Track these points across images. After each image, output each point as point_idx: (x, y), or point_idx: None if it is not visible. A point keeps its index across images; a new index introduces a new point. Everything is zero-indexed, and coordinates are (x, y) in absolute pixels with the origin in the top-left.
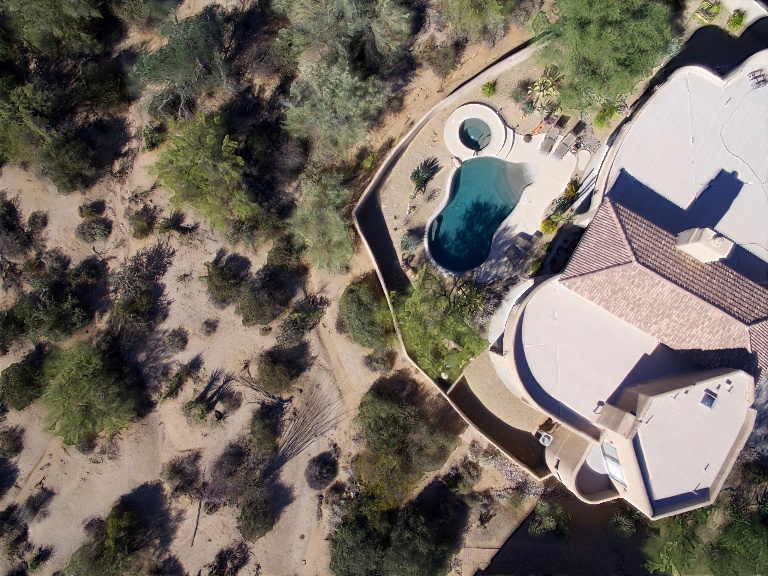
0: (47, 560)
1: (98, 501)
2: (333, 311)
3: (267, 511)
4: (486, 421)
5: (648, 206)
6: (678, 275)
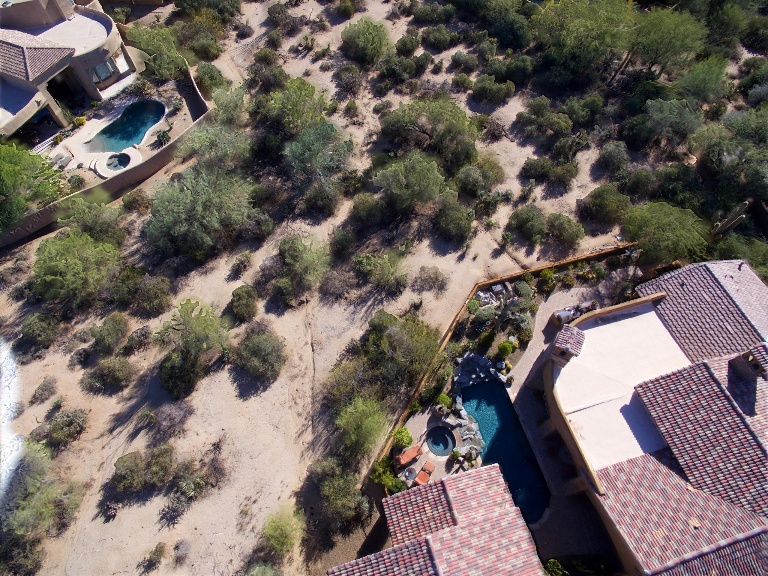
0: (385, 1)
1: (363, 17)
2: (234, 88)
3: (271, 13)
4: (147, 49)
5: (5, 99)
6: (1, 47)
